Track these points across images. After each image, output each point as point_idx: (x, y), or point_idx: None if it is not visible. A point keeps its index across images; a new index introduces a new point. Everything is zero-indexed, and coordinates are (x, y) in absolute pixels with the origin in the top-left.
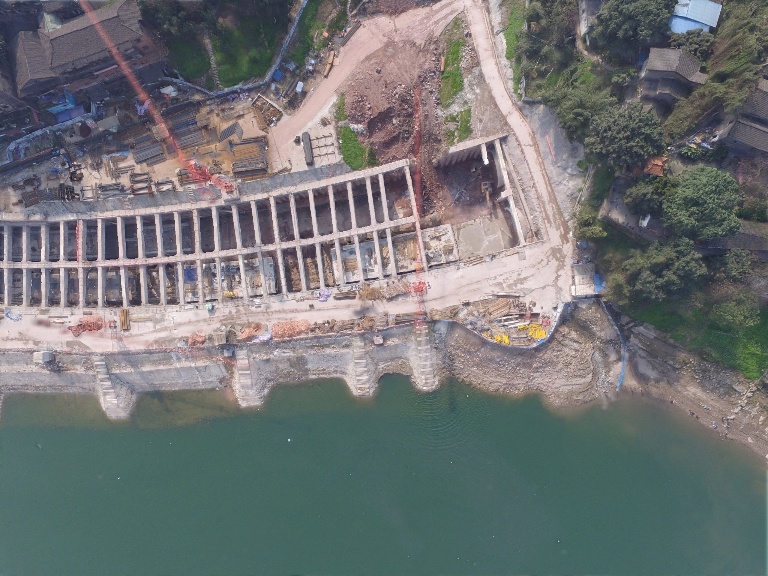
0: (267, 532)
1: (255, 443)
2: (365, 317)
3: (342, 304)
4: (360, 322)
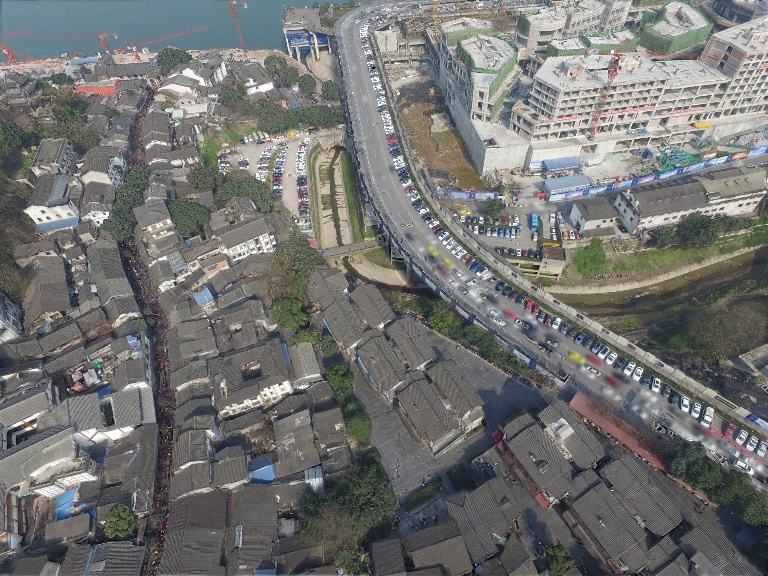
0: (94, 36)
1: (86, 52)
2: (3, 65)
3: (10, 68)
4: (7, 65)
